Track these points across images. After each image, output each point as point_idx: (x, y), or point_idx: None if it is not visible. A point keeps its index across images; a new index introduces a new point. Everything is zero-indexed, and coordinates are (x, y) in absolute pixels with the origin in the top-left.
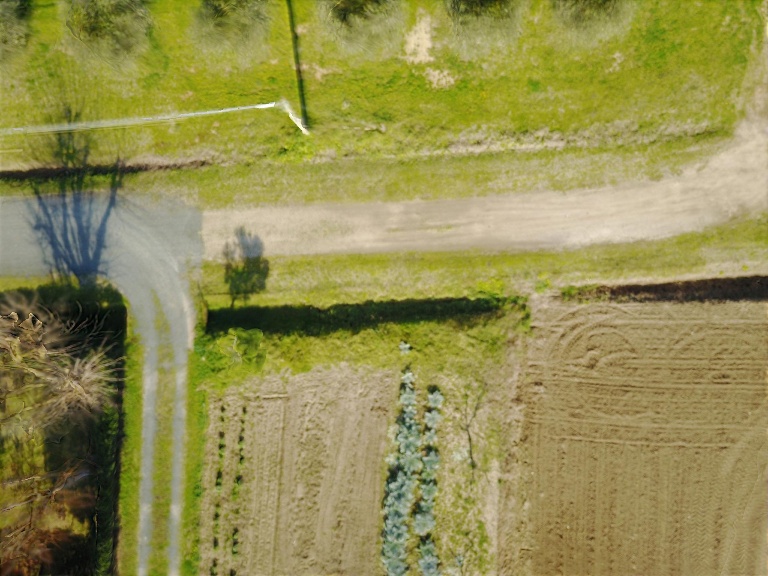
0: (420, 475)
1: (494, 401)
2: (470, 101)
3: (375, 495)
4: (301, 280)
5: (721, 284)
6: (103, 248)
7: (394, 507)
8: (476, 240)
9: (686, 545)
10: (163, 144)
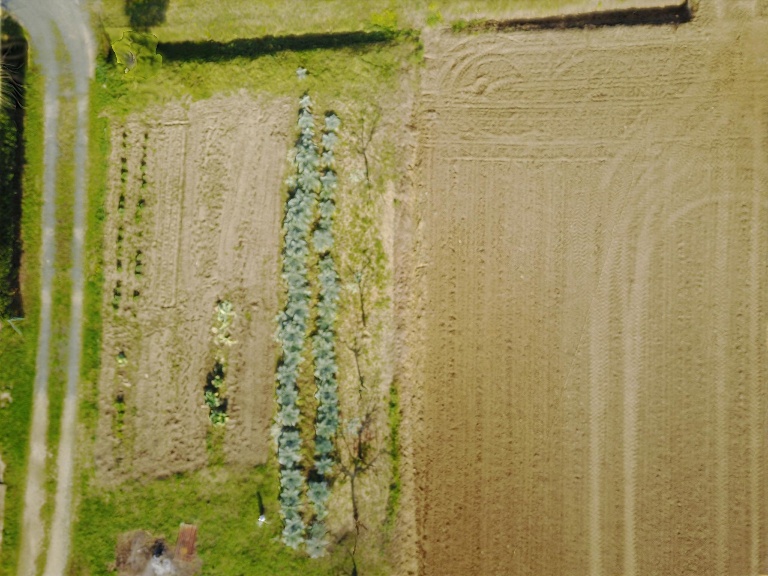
0: (318, 195)
1: (389, 124)
2: None
3: (275, 216)
4: (201, 12)
5: (601, 16)
6: None
7: (293, 222)
8: None
9: (569, 252)
10: None
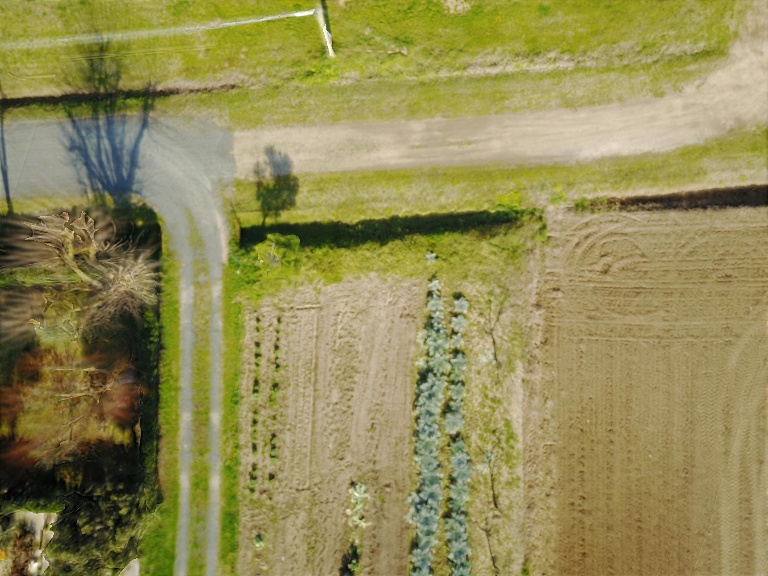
0: (448, 377)
1: (516, 305)
2: (486, 25)
3: (406, 397)
4: (330, 196)
5: (721, 193)
6: (137, 169)
7: (425, 406)
8: (495, 155)
9: (697, 432)
10: (194, 69)
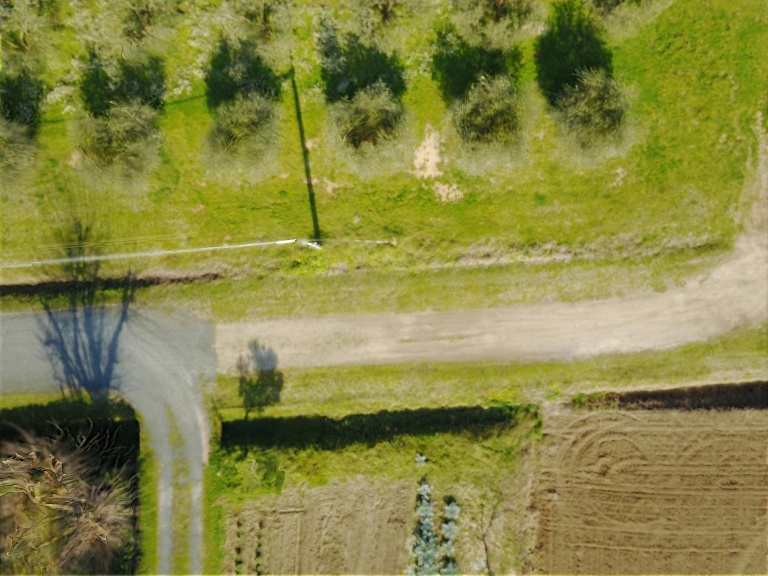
0: None
1: (509, 510)
2: (480, 214)
3: None
4: (315, 392)
5: (725, 389)
6: (115, 363)
7: None
8: (488, 350)
9: None
10: (175, 257)
